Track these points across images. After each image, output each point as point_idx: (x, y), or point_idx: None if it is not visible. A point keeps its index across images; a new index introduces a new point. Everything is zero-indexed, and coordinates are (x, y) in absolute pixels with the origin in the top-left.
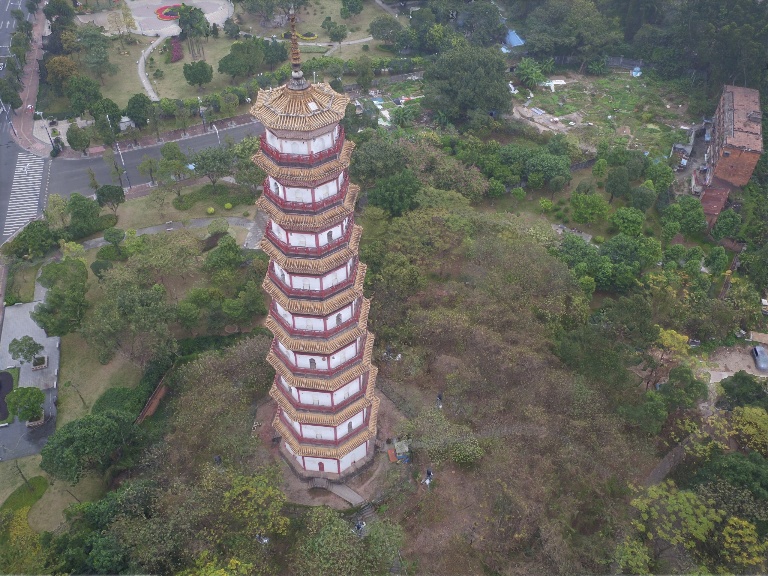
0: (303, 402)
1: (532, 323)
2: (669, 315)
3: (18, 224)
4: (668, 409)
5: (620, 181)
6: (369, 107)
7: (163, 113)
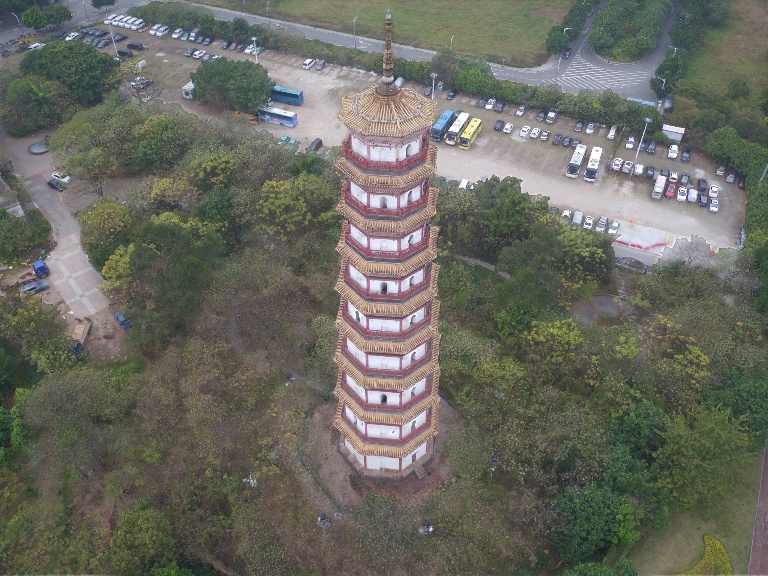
0: None
1: None
2: (51, 311)
3: None
4: None
5: None
6: None
7: None
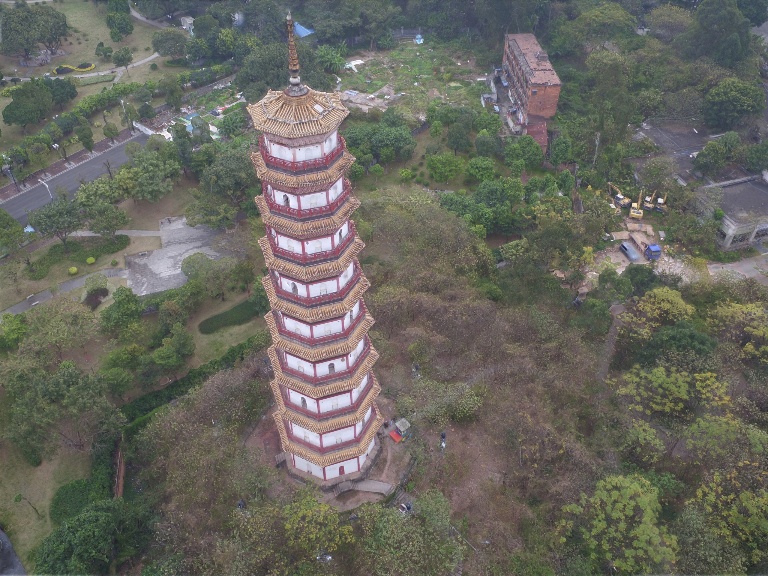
0: (323, 411)
1: (457, 278)
2: None
3: None
4: None
5: (460, 136)
6: (199, 123)
7: None
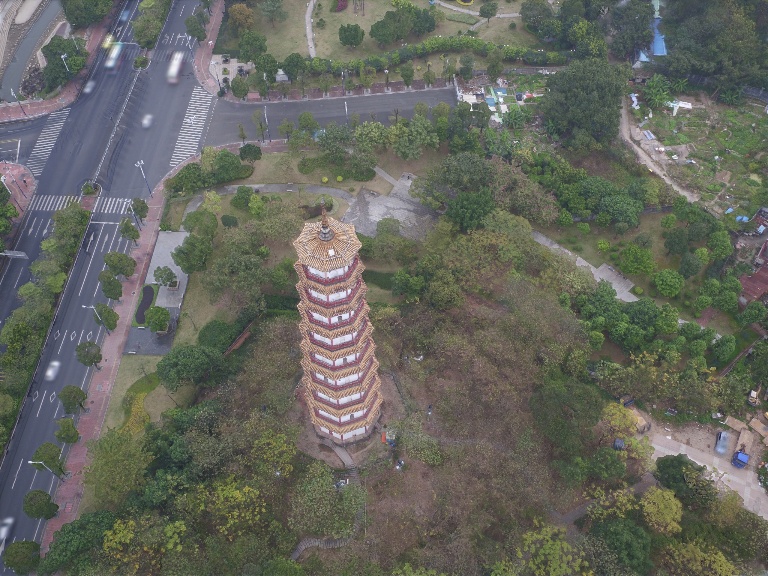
0: (320, 396)
1: (529, 364)
2: (647, 389)
3: (181, 157)
4: (590, 474)
5: (678, 242)
6: (482, 109)
7: (313, 71)
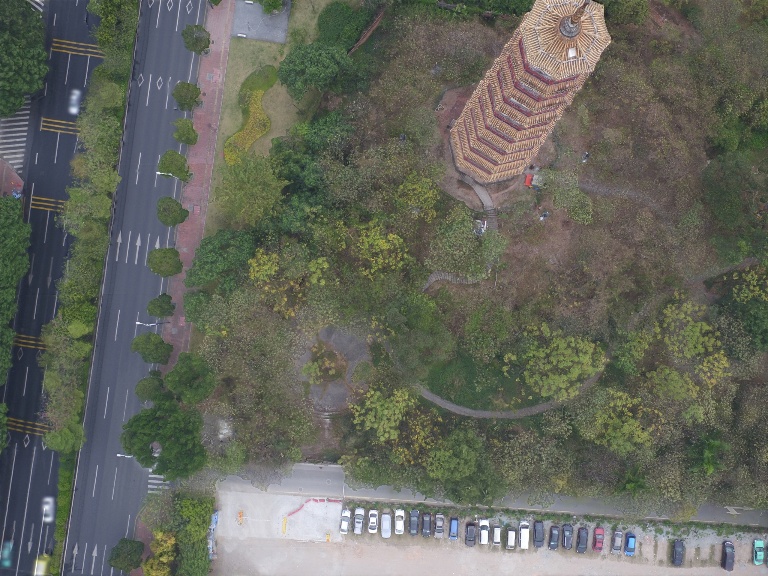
0: None
1: (708, 113)
2: None
3: None
4: (748, 256)
5: None
6: None
7: None
